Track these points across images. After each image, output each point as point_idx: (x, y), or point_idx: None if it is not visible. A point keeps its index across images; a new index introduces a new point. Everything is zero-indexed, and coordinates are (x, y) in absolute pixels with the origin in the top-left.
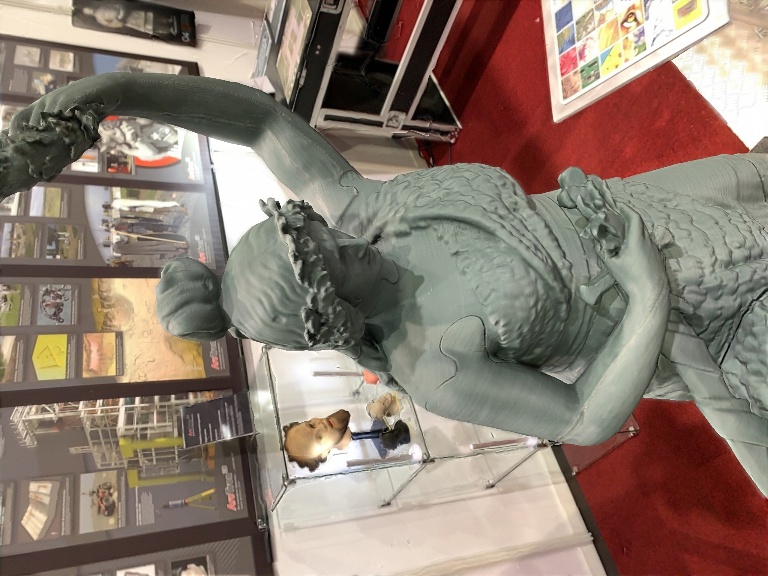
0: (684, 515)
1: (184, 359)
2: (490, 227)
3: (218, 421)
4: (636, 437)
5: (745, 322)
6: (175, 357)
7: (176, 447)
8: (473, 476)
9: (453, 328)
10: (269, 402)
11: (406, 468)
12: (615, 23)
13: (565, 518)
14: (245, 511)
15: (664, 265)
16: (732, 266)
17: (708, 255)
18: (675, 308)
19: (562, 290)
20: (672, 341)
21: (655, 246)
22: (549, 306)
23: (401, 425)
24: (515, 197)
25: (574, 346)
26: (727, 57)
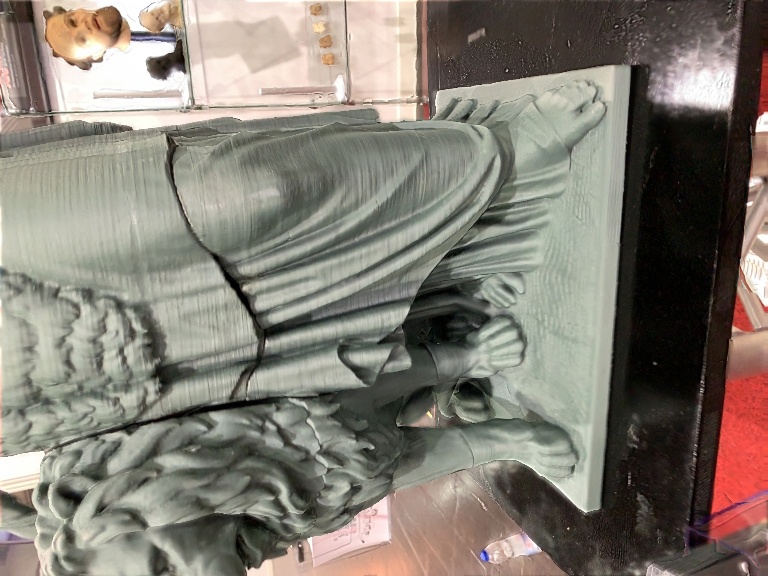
0: None
1: None
2: None
3: None
4: None
5: None
6: None
7: None
8: None
9: None
10: None
11: (229, 63)
12: None
13: None
14: (22, 90)
15: None
16: (38, 405)
17: None
18: None
19: None
20: None
21: None
22: None
23: (178, 49)
24: None
25: None
26: None
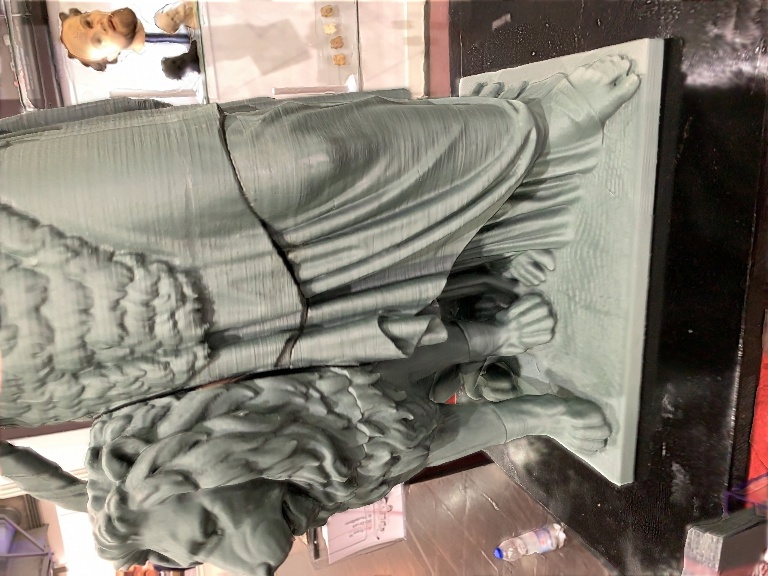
0: None
1: None
2: None
3: None
4: None
5: None
6: None
7: None
8: None
9: None
10: None
11: (240, 65)
12: None
13: None
14: (36, 92)
15: None
16: (90, 369)
17: (32, 370)
18: None
19: None
20: None
21: None
22: None
23: (193, 49)
24: None
25: None
26: None
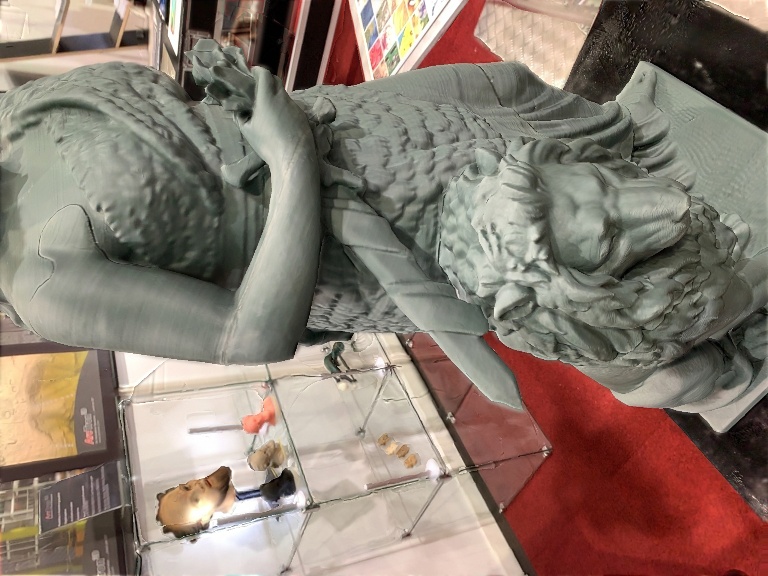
0: (608, 533)
1: (52, 437)
2: (92, 102)
3: (81, 498)
4: (550, 457)
5: (444, 201)
6: (41, 436)
7: (37, 536)
8: (390, 528)
9: (50, 223)
10: (152, 474)
11: (314, 529)
12: (403, 5)
13: (498, 562)
14: None
15: (329, 139)
16: None
17: (396, 134)
18: (340, 182)
19: (192, 169)
20: (341, 220)
21: (296, 107)
22: (179, 190)
23: (286, 473)
24: (150, 83)
25: (249, 252)
26: (562, 59)
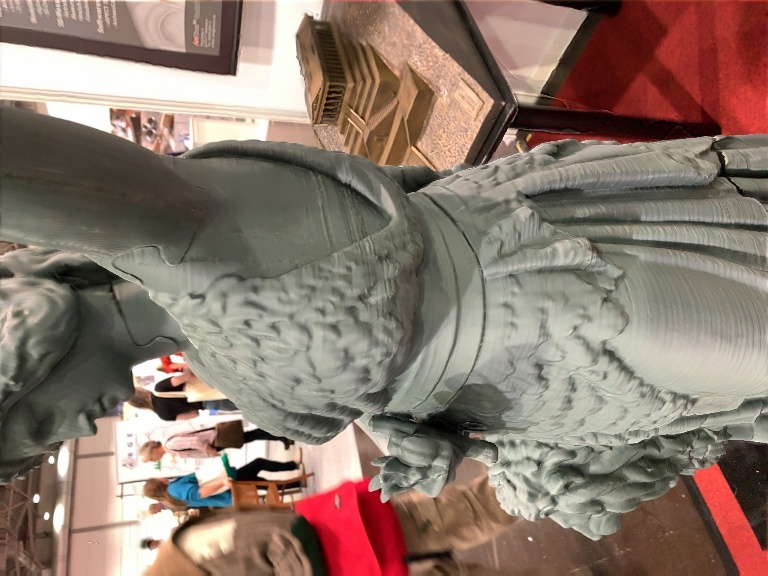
0: None
1: None
2: None
3: None
4: None
5: None
6: None
7: None
8: None
9: None
10: None
11: None
12: None
13: None
14: None
15: None
16: None
17: None
18: None
19: None
20: None
21: None
22: None
23: None
24: None
25: None
26: None
